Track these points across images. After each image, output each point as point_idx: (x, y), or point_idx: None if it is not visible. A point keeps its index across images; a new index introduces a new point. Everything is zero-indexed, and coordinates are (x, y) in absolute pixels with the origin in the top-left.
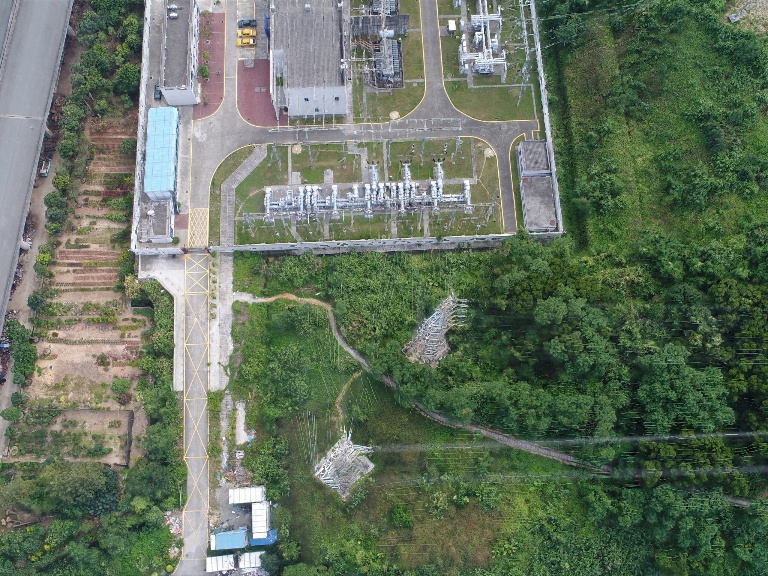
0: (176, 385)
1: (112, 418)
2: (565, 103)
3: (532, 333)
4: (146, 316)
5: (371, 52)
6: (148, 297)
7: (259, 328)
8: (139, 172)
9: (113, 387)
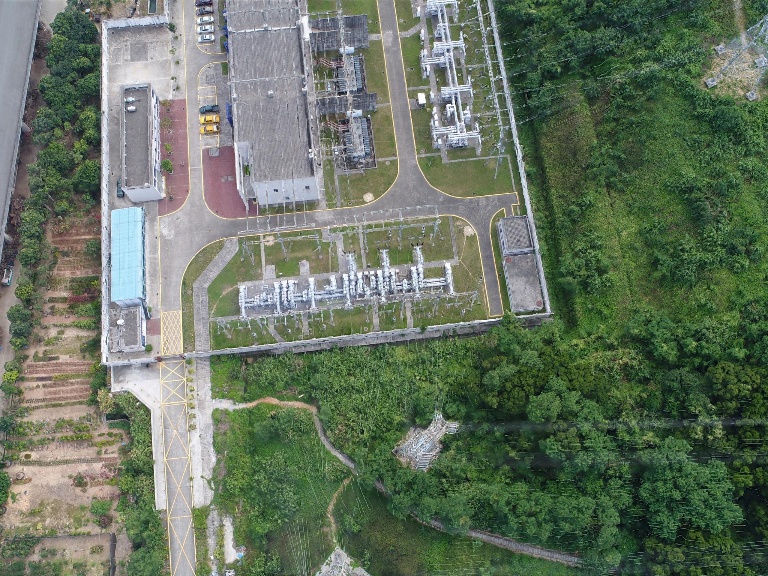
0: (158, 504)
1: (93, 543)
2: (543, 173)
3: (526, 429)
4: (123, 429)
5: (340, 132)
6: (123, 411)
7: (242, 437)
8: (106, 277)
9: (92, 510)
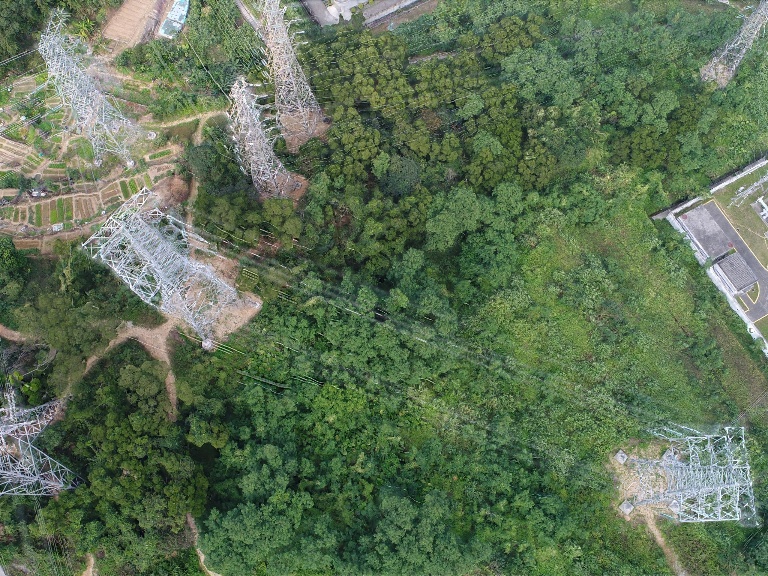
0: None
1: None
2: None
3: None
4: None
5: None
6: None
7: None
8: None
9: None
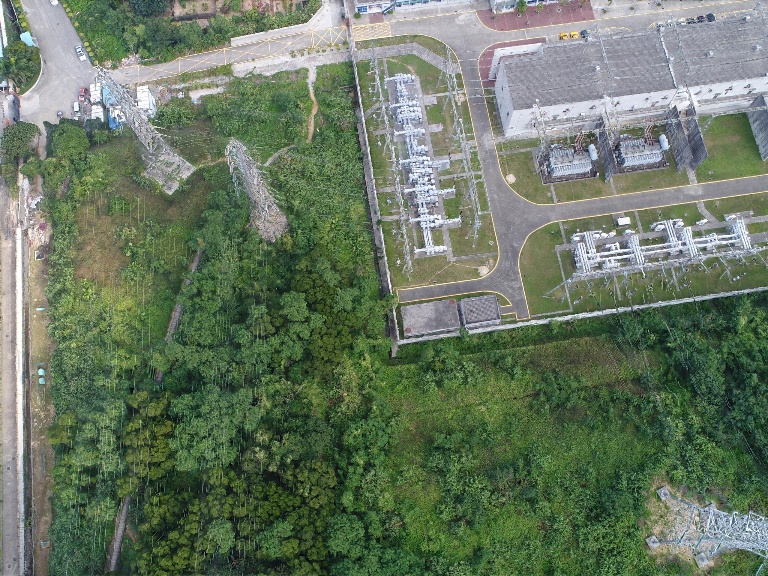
0: (236, 40)
1: (210, 4)
2: None
3: None
4: None
5: None
6: None
7: None
8: None
9: None
